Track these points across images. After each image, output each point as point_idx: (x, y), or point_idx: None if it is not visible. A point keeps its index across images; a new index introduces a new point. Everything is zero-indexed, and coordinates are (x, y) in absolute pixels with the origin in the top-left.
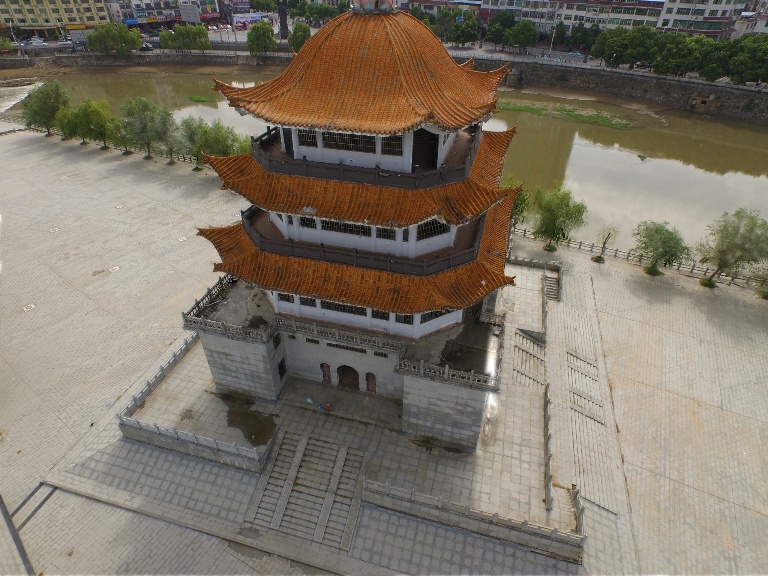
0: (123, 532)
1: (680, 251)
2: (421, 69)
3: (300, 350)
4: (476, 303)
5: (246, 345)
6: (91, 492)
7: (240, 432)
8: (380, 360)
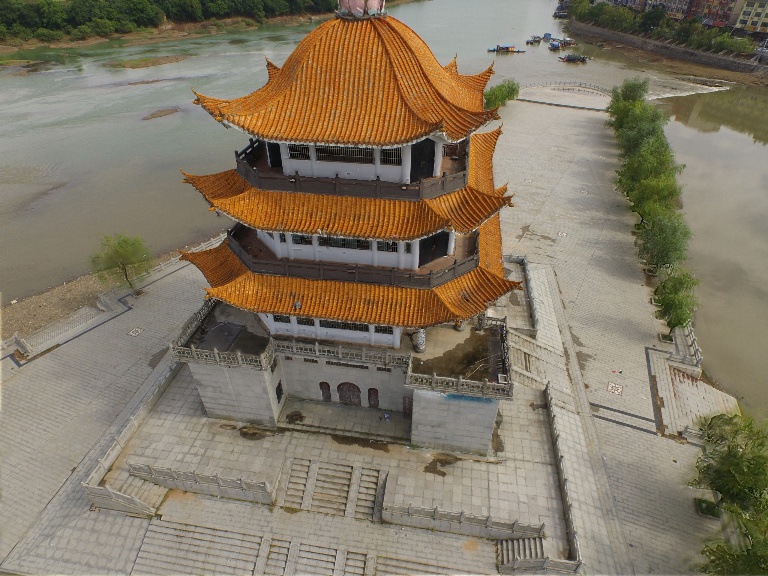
0: None
1: None
2: None
3: None
4: None
5: None
6: None
7: None
8: None
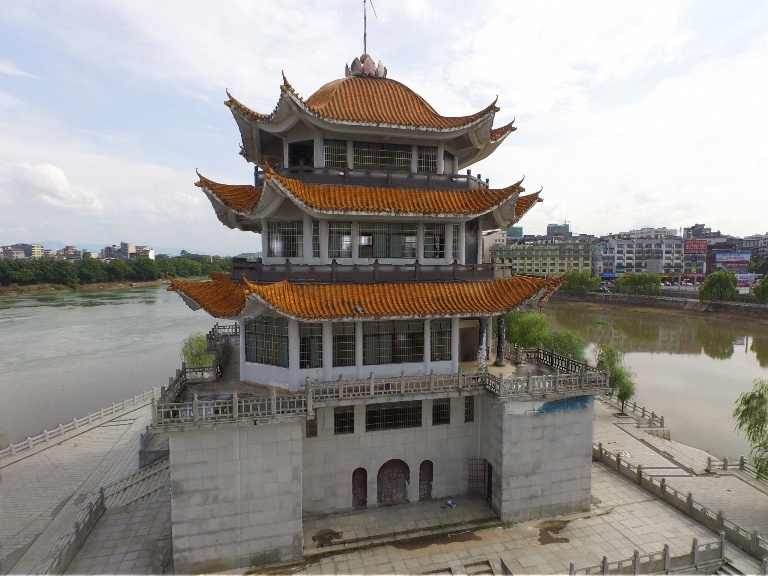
0: (92, 454)
1: None
2: None
3: None
4: None
5: None
6: (128, 432)
7: None
8: None
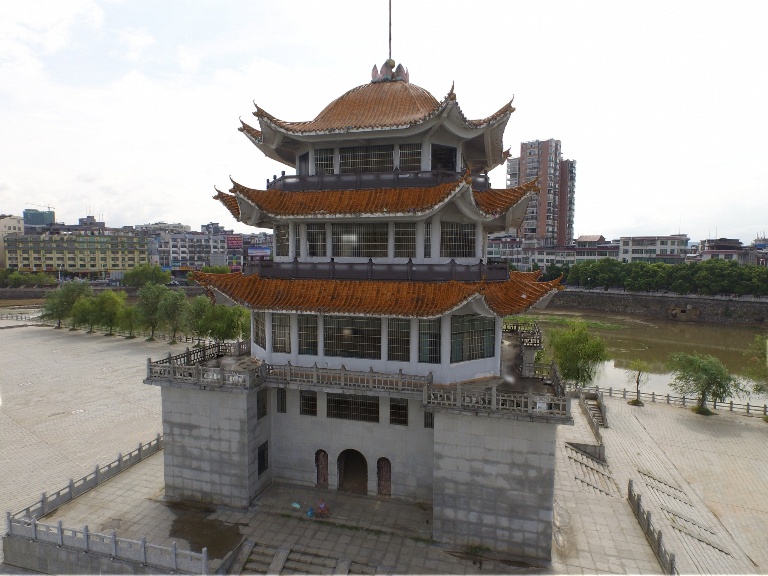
0: None
1: (726, 383)
2: None
3: (290, 431)
4: (514, 362)
5: (221, 405)
6: None
7: (186, 543)
8: (397, 431)
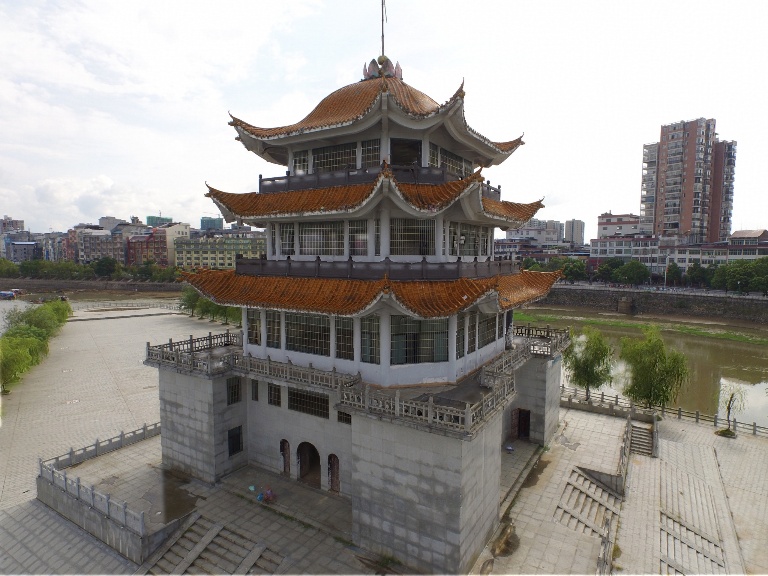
0: None
1: None
2: (407, 99)
3: (261, 418)
4: None
5: (196, 388)
6: None
7: (149, 505)
8: (344, 430)
